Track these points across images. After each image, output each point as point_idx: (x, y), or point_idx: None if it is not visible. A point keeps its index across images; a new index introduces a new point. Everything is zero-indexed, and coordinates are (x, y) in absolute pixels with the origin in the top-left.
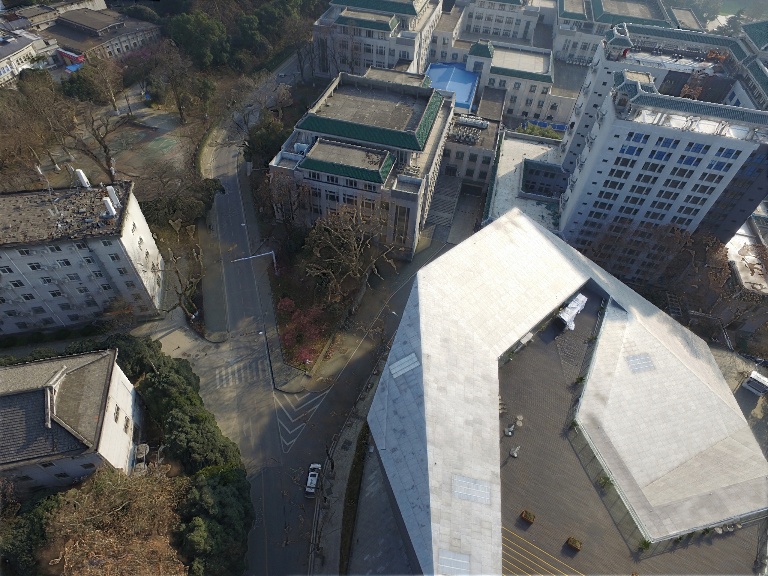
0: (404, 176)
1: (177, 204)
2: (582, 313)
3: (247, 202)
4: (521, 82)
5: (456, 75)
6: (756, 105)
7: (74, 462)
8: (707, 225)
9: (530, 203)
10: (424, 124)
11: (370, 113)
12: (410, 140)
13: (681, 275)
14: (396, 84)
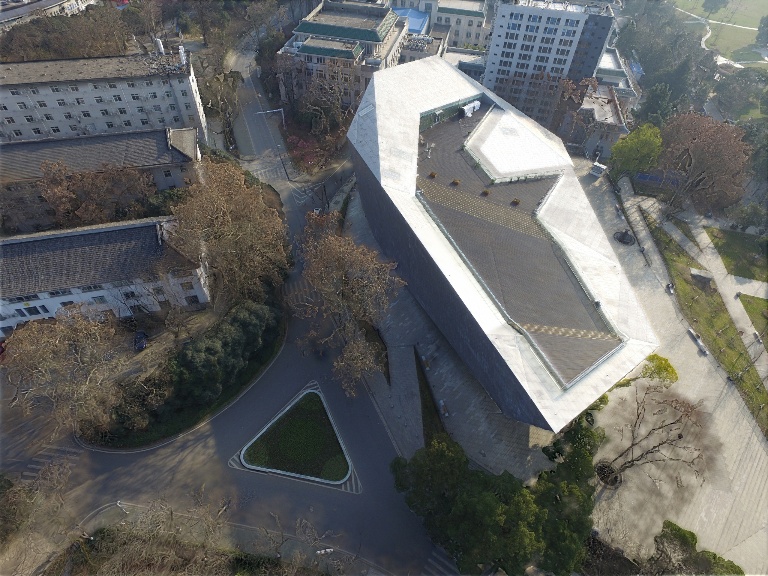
0: (370, 59)
1: (213, 84)
2: (477, 111)
3: (259, 92)
4: (461, 18)
5: (411, 14)
6: None
7: (181, 175)
8: None
9: None
10: (383, 27)
11: (345, 24)
12: (373, 35)
13: (563, 125)
14: (364, 6)
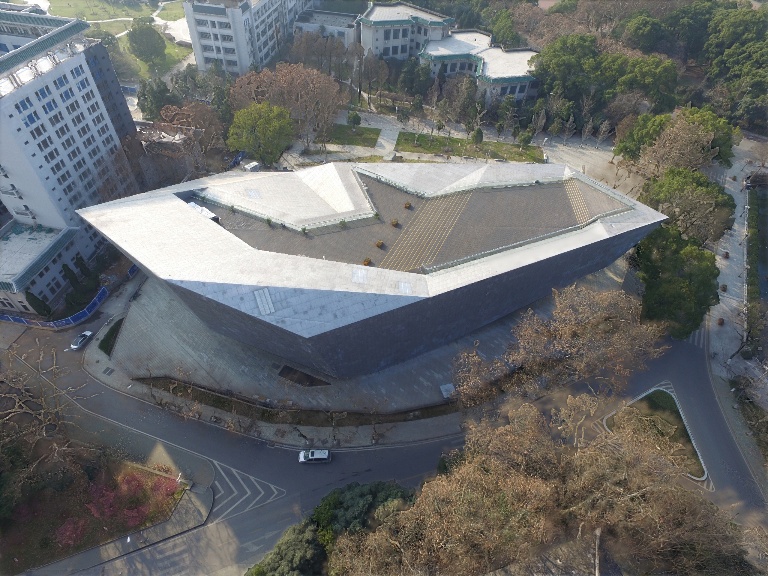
0: None
1: None
2: None
3: None
4: None
5: None
6: (23, 36)
7: None
8: (119, 130)
9: (1, 246)
10: None
11: None
12: None
13: (145, 175)
14: None
